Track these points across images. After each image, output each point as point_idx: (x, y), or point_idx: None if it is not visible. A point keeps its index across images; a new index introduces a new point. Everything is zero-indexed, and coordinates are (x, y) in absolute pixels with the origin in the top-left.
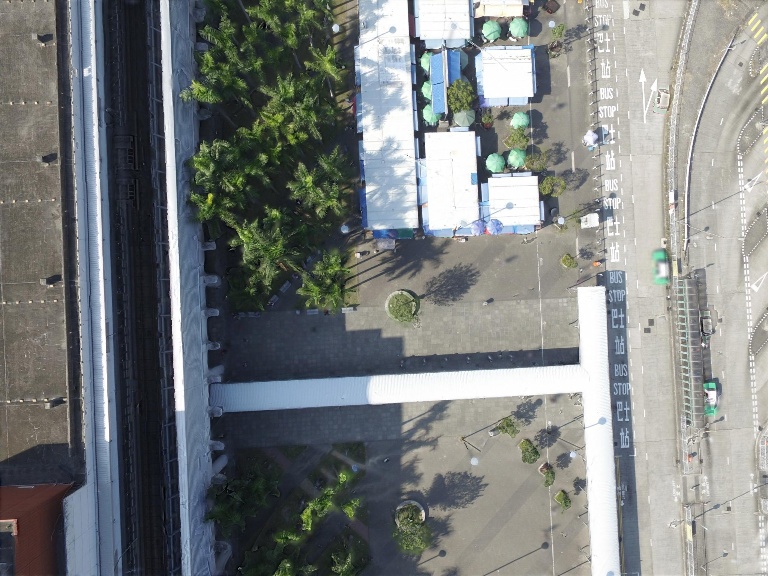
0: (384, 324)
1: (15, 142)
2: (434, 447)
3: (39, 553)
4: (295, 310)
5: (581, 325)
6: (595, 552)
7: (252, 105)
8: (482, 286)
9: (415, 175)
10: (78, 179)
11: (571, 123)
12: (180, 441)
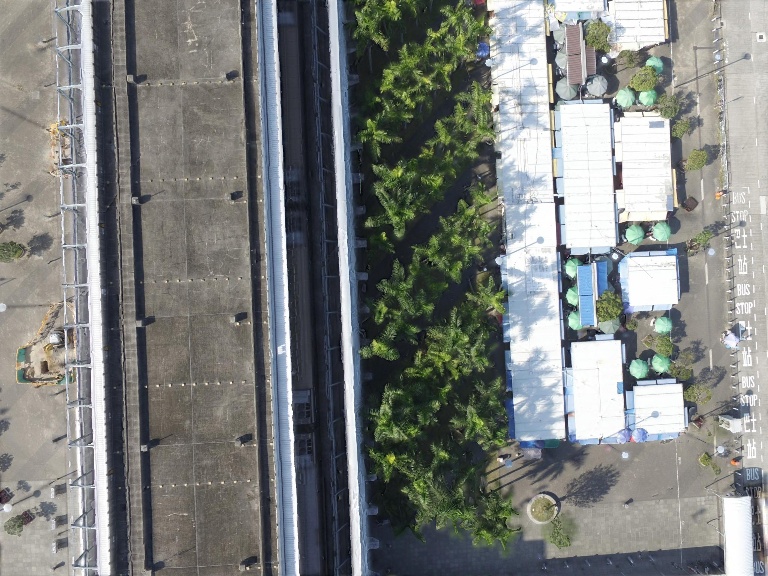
0: (525, 527)
1: (210, 423)
2: None
3: None
4: None
5: (727, 536)
6: None
7: (418, 342)
8: (622, 487)
9: (562, 385)
10: (276, 463)
11: (709, 321)
12: None
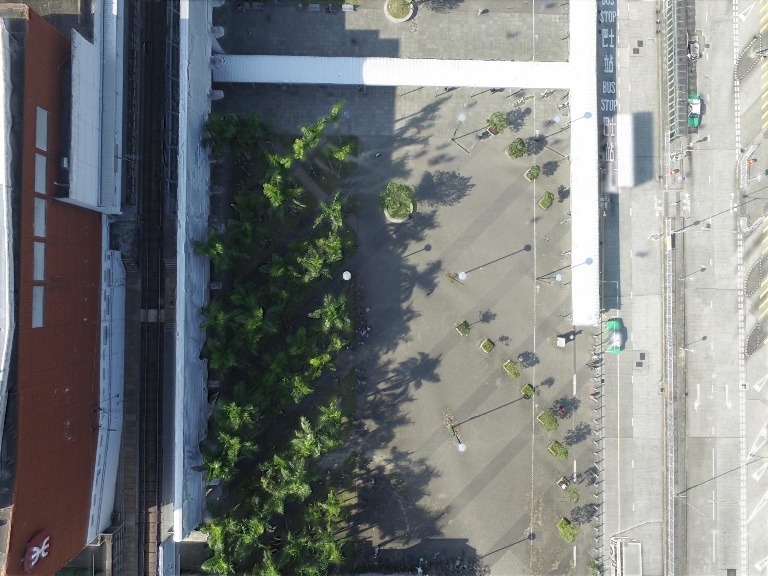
0: (382, 26)
1: None
2: (425, 145)
3: (47, 65)
4: None
5: (571, 24)
6: (575, 240)
7: None
8: None
9: None
10: None
11: None
12: (183, 47)
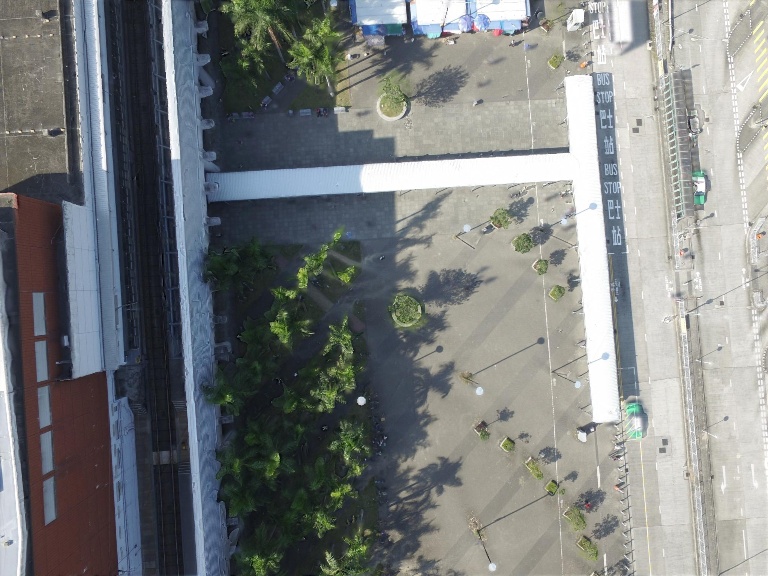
0: (376, 125)
1: None
2: (428, 244)
3: (39, 245)
4: (288, 111)
5: (569, 113)
6: (590, 335)
7: None
8: (471, 88)
9: None
10: None
11: None
12: (176, 189)
